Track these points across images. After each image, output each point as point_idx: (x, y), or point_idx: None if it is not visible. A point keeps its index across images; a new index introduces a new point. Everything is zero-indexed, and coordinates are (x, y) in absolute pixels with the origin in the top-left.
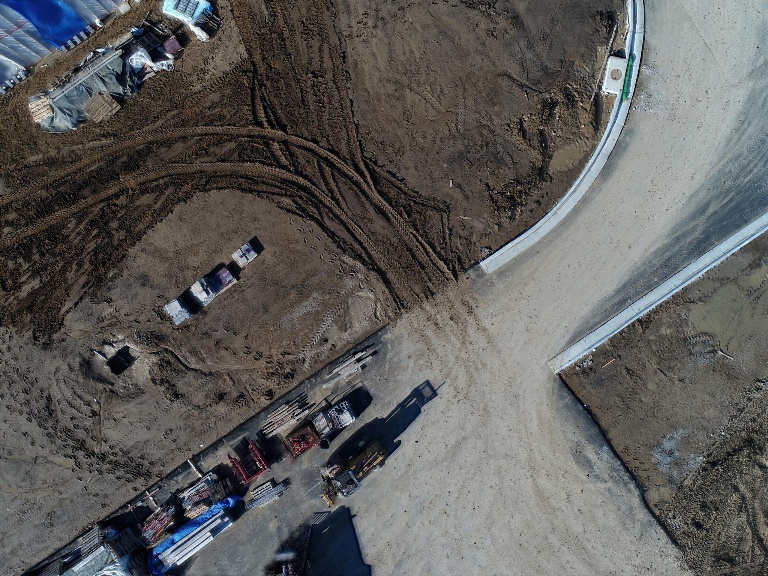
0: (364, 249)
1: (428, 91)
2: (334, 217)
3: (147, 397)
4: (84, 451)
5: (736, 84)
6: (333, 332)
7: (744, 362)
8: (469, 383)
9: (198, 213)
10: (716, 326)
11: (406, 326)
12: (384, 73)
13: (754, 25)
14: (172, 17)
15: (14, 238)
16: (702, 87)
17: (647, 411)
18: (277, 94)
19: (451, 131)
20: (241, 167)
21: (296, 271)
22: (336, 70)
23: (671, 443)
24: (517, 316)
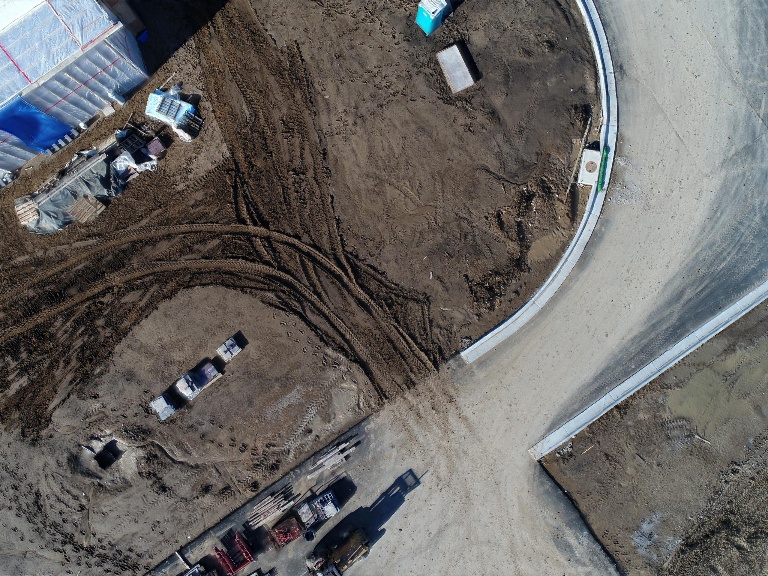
0: (346, 341)
1: (407, 186)
2: (316, 311)
3: (135, 490)
4: (73, 545)
5: (708, 174)
6: (317, 423)
7: (721, 446)
8: (451, 471)
9: (183, 309)
10: (693, 411)
11: (389, 416)
12: (364, 169)
13: (725, 117)
14: (155, 118)
15: (2, 337)
16: (675, 178)
17: (627, 496)
18: (259, 191)
19: (430, 224)
20: (224, 263)
21: (280, 364)
22: (316, 167)
23: (651, 527)
24: (498, 405)
